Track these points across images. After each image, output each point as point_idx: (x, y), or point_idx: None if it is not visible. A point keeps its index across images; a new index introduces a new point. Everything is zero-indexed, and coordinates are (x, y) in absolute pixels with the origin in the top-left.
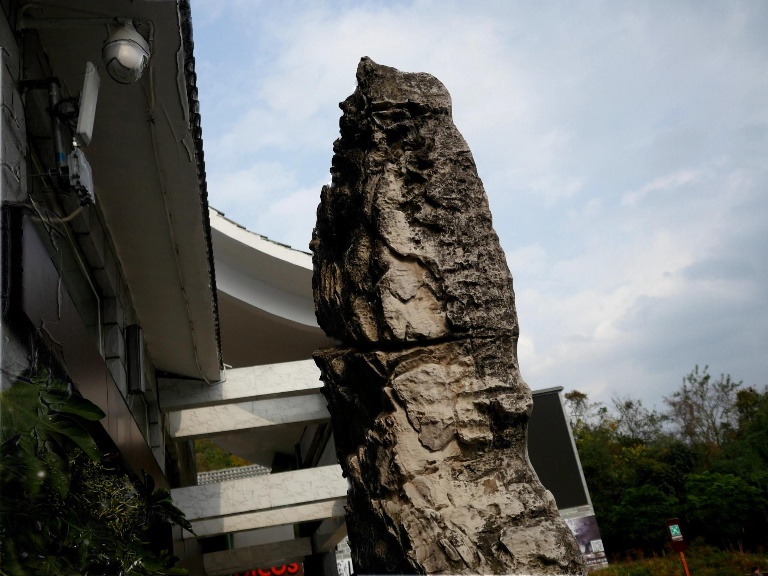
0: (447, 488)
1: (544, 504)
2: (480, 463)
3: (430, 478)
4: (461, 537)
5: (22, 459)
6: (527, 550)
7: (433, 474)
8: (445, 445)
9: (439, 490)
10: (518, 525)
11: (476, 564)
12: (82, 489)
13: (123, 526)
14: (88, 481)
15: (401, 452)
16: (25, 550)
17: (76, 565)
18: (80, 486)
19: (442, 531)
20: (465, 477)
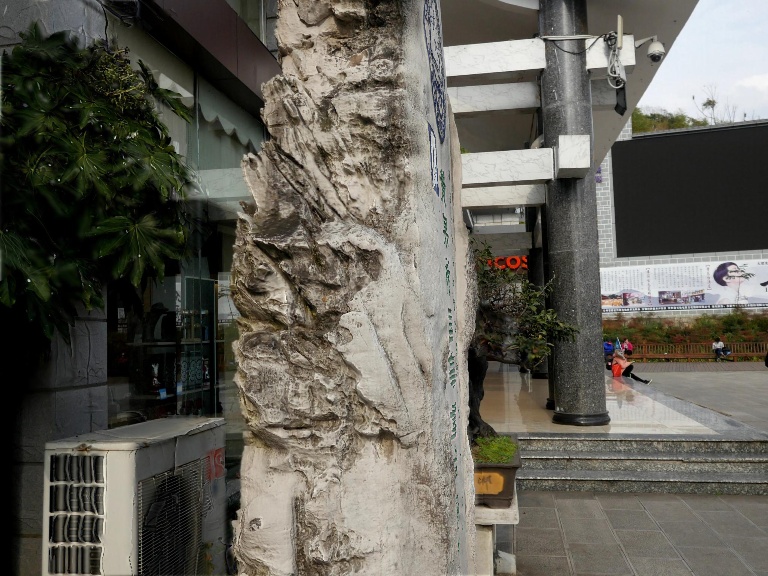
0: (317, 61)
1: (390, 76)
2: (356, 41)
3: (306, 52)
4: (305, 99)
5: (73, 51)
6: (348, 110)
7: (310, 48)
8: (321, 20)
9: (310, 62)
10: (357, 92)
11: (312, 122)
12: (91, 69)
13: (126, 104)
14: (100, 64)
15: (281, 25)
16: (26, 102)
17: (78, 125)
18: (91, 67)
19: (293, 94)
20: (342, 54)
